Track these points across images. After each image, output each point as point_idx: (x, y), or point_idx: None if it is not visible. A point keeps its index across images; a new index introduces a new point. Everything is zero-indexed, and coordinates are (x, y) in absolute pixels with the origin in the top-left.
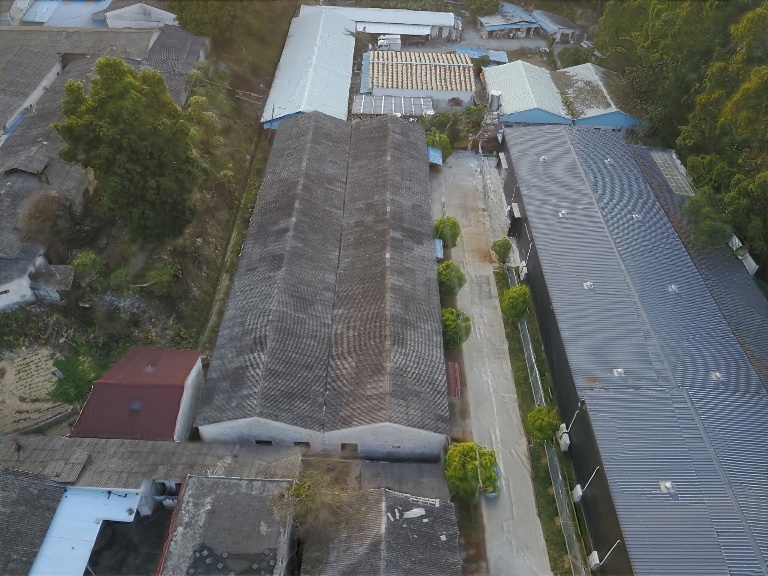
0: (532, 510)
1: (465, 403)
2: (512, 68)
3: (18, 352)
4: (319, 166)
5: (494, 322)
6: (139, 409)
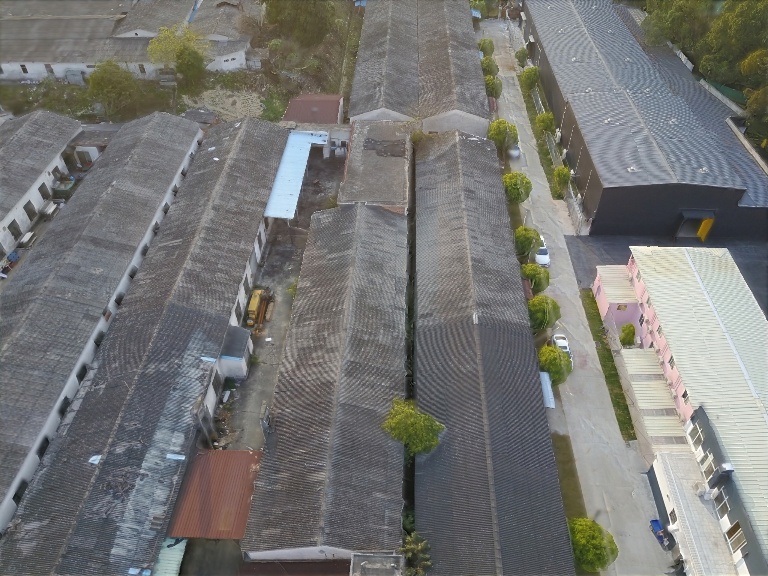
0: (538, 164)
1: None
2: None
3: (242, 93)
4: (399, 16)
5: (517, 96)
6: (317, 111)
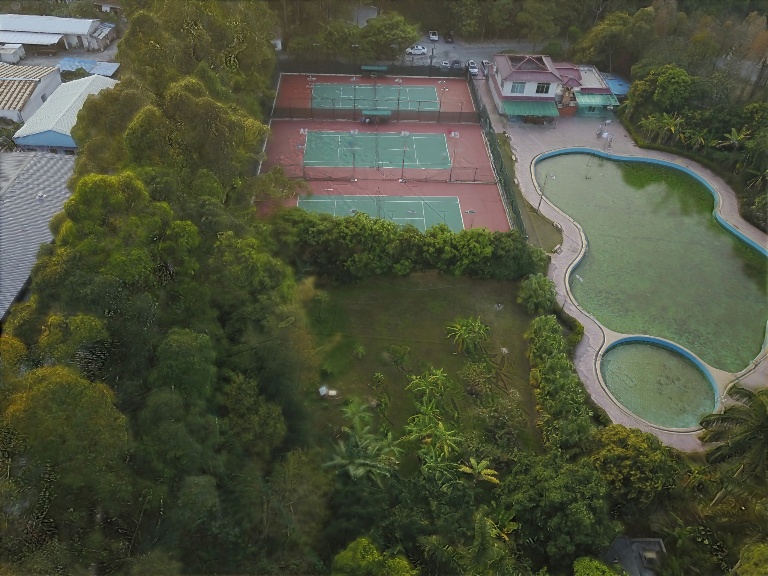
0: None
1: None
2: (80, 83)
3: None
4: None
5: None
6: None
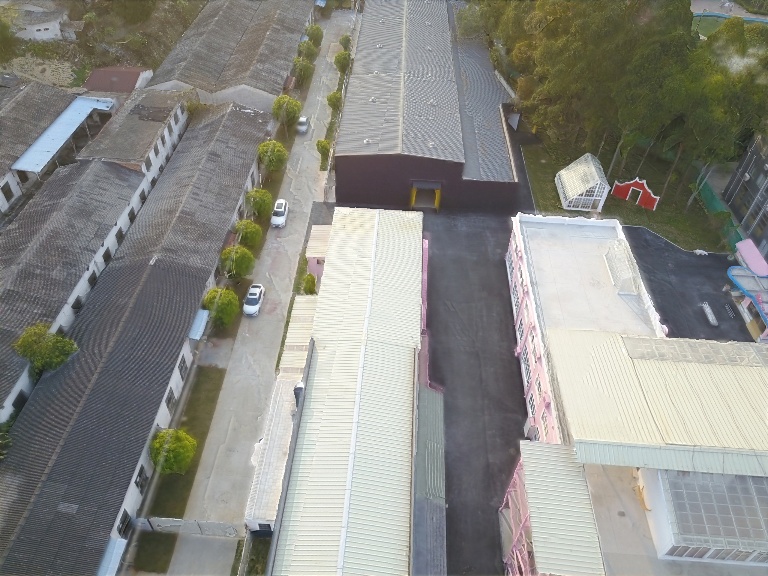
0: (322, 139)
1: (302, 106)
2: None
3: (53, 62)
4: (240, 0)
5: (333, 79)
6: (116, 81)
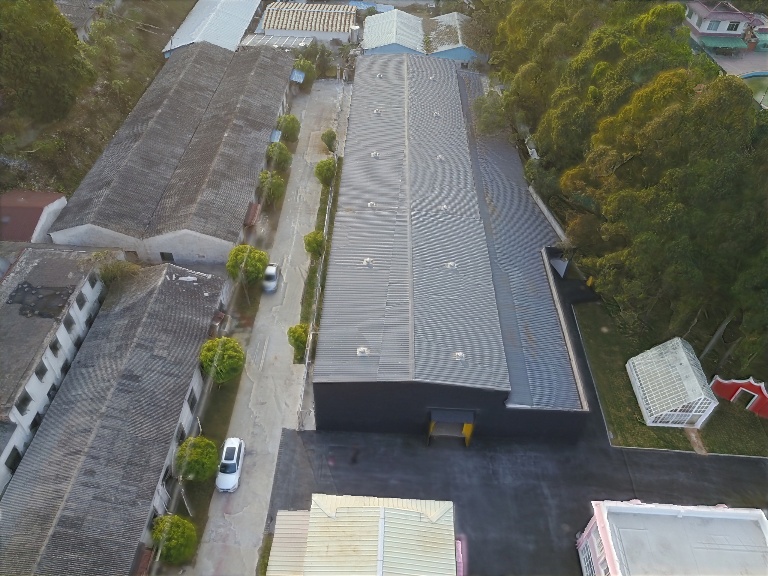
0: (298, 301)
1: (271, 239)
2: (388, 15)
3: None
4: (194, 79)
5: (314, 192)
6: (8, 222)
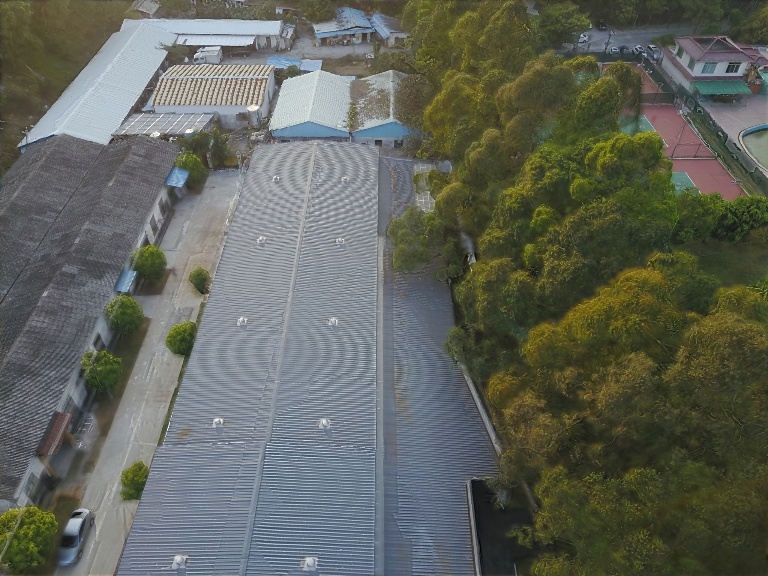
0: None
1: (95, 455)
2: (308, 79)
3: None
4: (34, 195)
5: (173, 360)
6: None
